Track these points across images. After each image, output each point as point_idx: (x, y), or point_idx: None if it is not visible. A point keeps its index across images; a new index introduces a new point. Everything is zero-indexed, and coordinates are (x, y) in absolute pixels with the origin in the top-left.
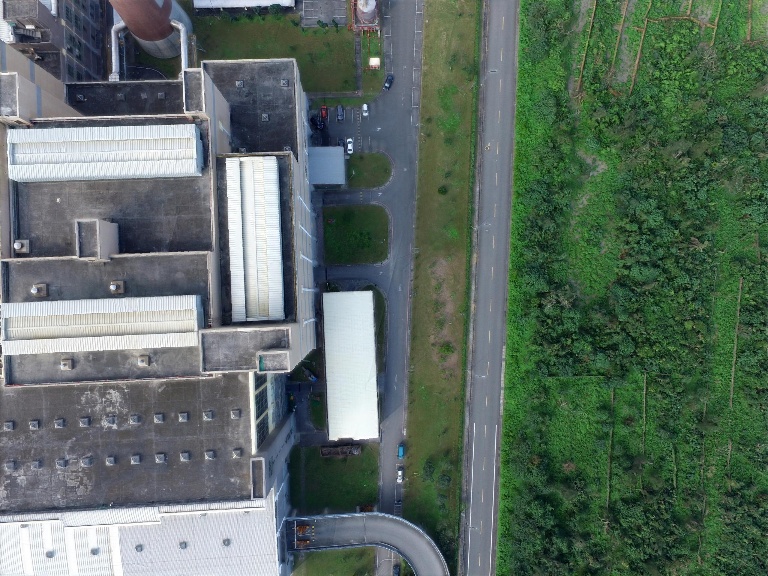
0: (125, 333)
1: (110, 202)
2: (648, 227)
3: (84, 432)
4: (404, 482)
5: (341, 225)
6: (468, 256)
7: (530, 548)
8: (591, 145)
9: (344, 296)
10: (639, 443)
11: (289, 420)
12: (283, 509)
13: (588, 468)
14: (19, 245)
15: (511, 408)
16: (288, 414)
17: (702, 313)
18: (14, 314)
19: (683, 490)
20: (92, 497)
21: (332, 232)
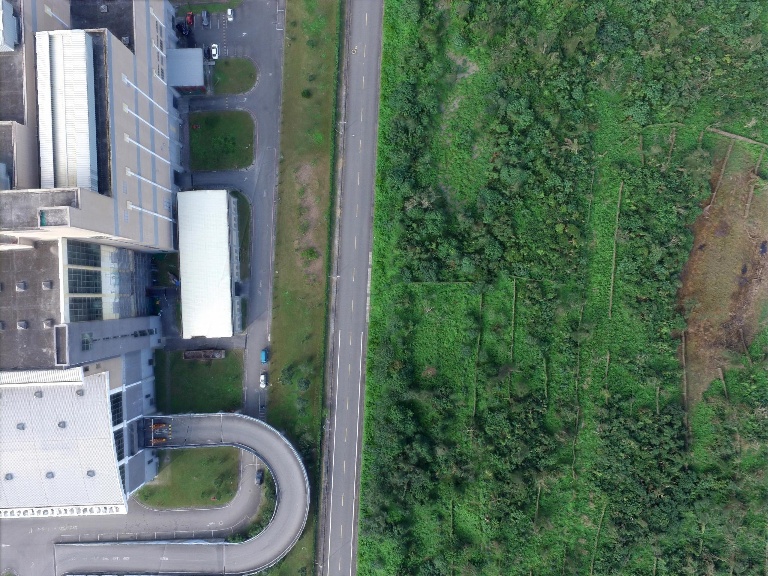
0: None
1: None
2: (520, 129)
3: None
4: (268, 388)
5: (206, 131)
6: (331, 159)
7: None
8: (456, 43)
9: (197, 195)
10: (507, 351)
11: (145, 319)
12: (140, 407)
13: (455, 376)
14: None
15: (377, 315)
16: (148, 315)
17: (575, 217)
18: None
19: (556, 401)
20: None
21: (197, 138)
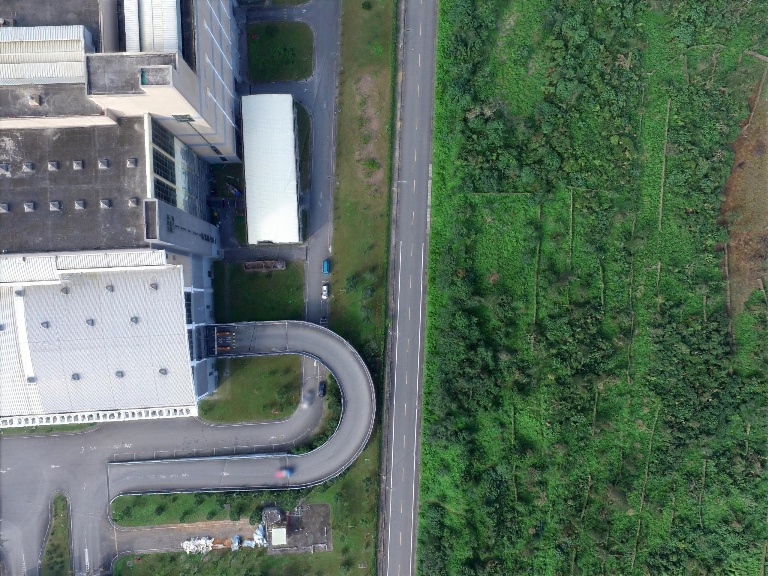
0: None
1: None
2: (574, 45)
3: None
4: (330, 299)
5: (265, 41)
6: (392, 71)
7: (455, 359)
8: None
9: (263, 98)
10: (566, 259)
11: (208, 225)
12: (203, 315)
13: (515, 286)
14: None
15: (438, 226)
16: None
17: (628, 129)
18: None
19: (611, 308)
20: None
21: (256, 48)
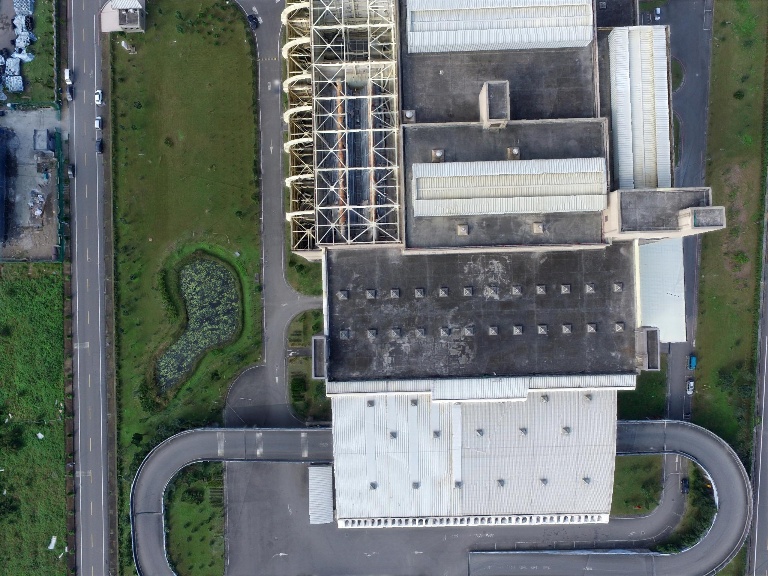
0: (532, 195)
1: (492, 74)
2: None
3: (467, 302)
4: (693, 394)
5: None
6: (766, 162)
7: None
8: None
9: None
10: None
11: None
12: None
13: None
14: (411, 113)
15: None
16: None
17: None
18: (427, 174)
19: None
20: (474, 366)
21: None
